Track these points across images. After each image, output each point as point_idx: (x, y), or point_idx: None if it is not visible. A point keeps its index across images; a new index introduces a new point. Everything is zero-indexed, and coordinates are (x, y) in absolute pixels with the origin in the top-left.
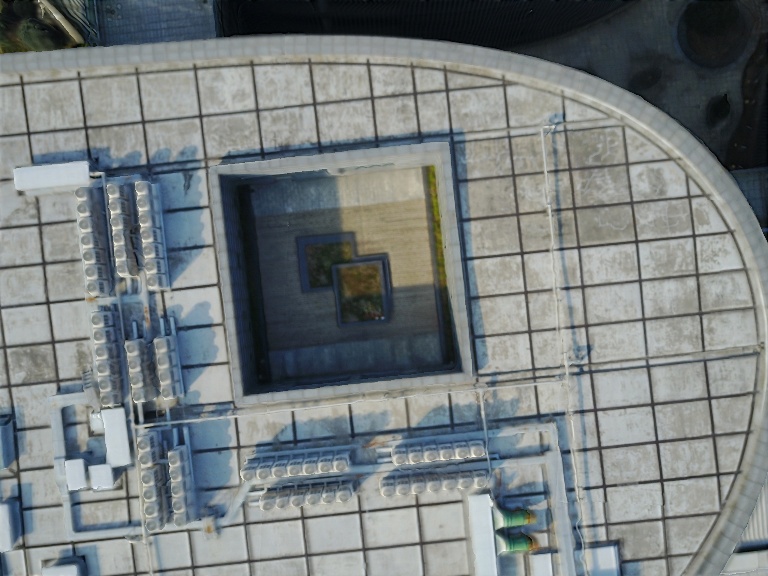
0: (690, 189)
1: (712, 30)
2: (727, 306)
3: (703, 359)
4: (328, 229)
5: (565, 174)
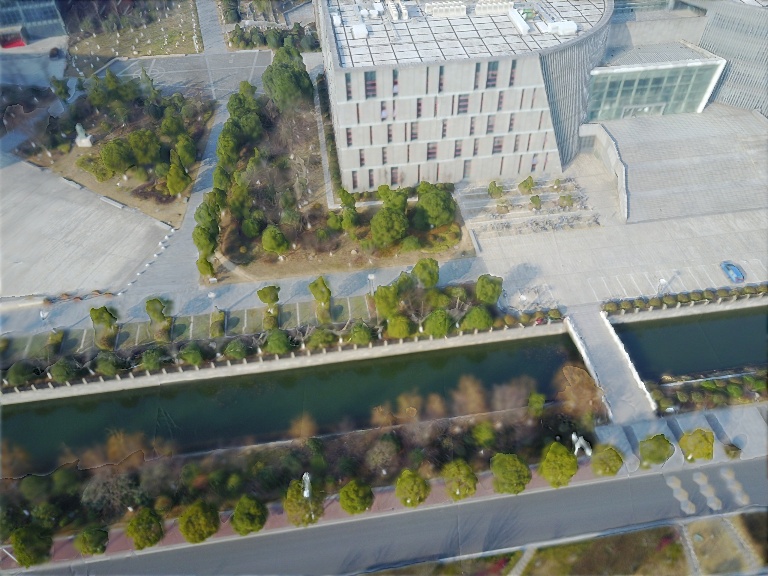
0: None
1: None
2: None
3: None
4: None
5: None
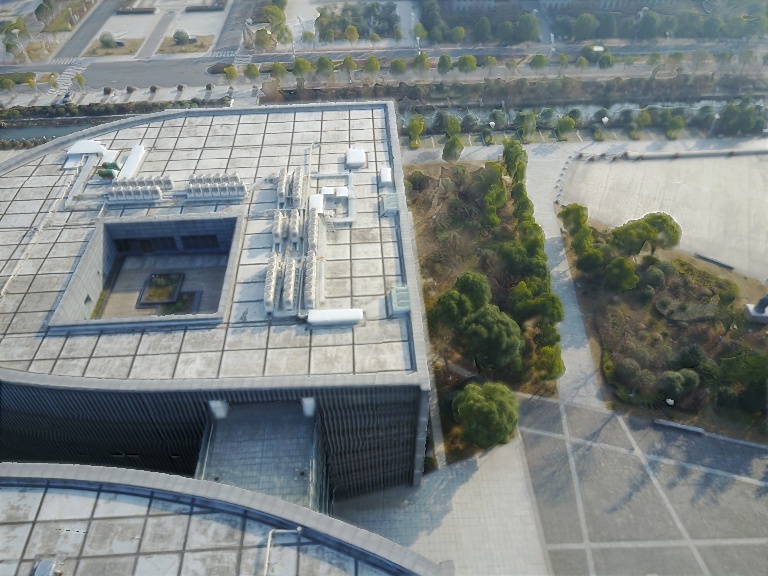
0: None
1: None
2: None
3: None
4: None
5: None
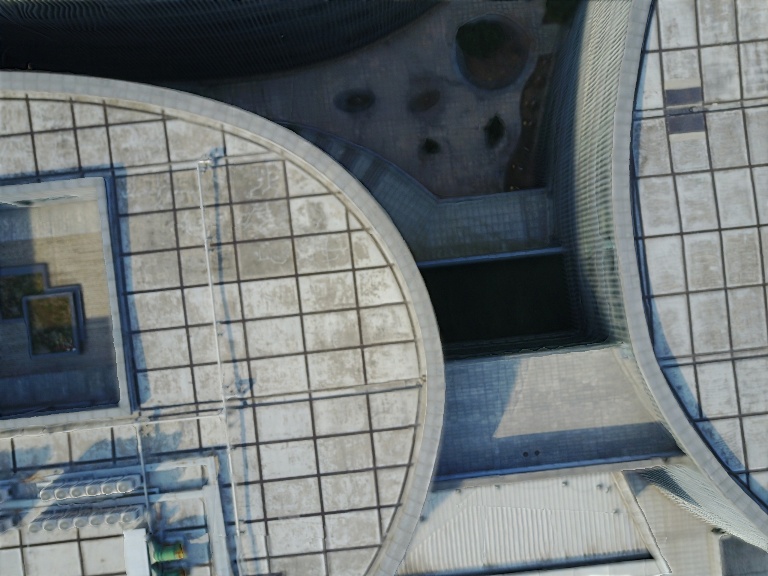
0: (350, 223)
1: (478, 53)
2: (388, 339)
3: (366, 392)
4: (20, 261)
5: (226, 208)
